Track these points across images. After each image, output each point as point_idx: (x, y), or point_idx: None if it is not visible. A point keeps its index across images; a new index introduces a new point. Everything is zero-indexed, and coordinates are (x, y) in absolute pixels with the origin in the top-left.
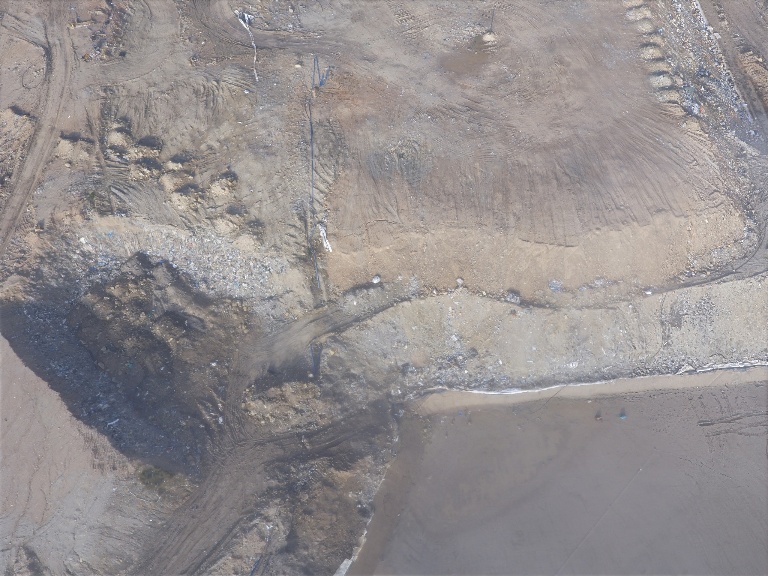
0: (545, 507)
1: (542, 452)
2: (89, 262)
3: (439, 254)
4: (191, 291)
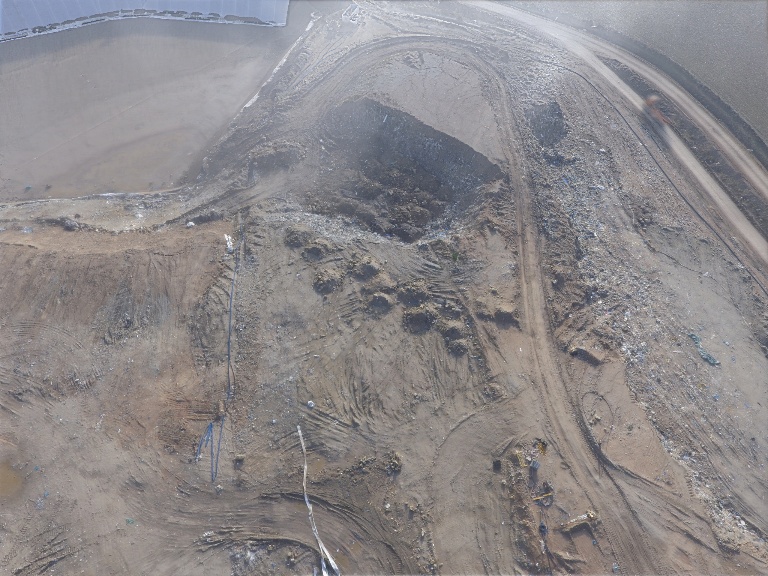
0: (114, 140)
1: (103, 167)
2: (452, 232)
3: (124, 244)
4: (357, 216)
